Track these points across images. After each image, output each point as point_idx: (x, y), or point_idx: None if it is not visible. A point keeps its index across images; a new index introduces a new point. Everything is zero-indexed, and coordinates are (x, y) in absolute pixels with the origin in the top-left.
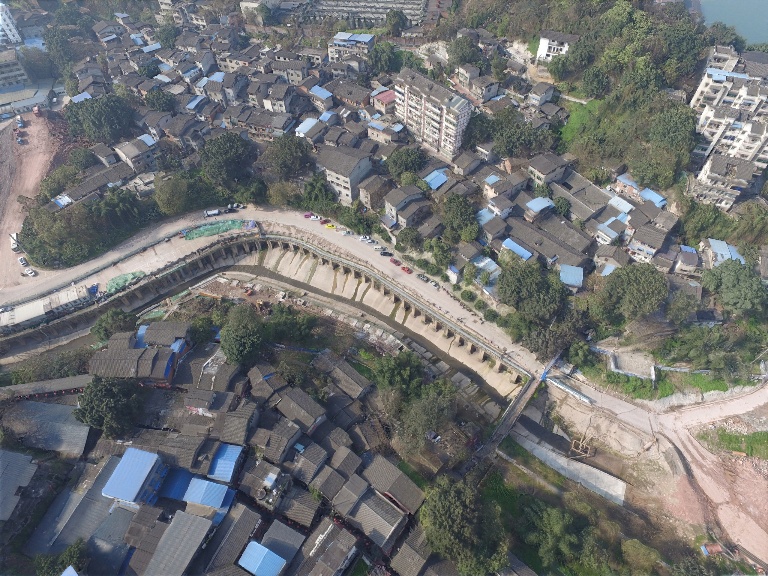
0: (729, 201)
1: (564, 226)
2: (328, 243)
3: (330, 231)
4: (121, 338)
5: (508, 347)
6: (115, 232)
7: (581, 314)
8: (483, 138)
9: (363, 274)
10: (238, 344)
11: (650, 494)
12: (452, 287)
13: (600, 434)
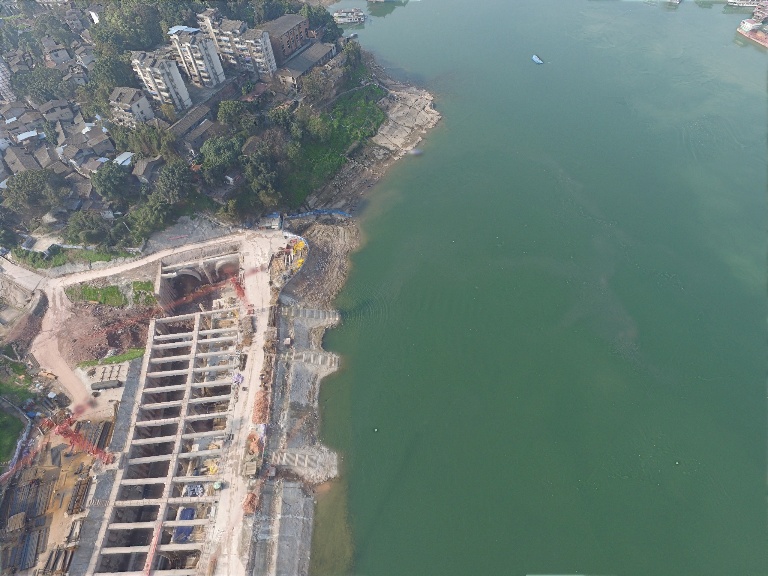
0: (134, 122)
1: (46, 151)
2: None
3: None
4: None
5: None
6: None
7: (3, 208)
8: (23, 91)
9: None
10: None
11: (7, 329)
12: None
13: (7, 294)
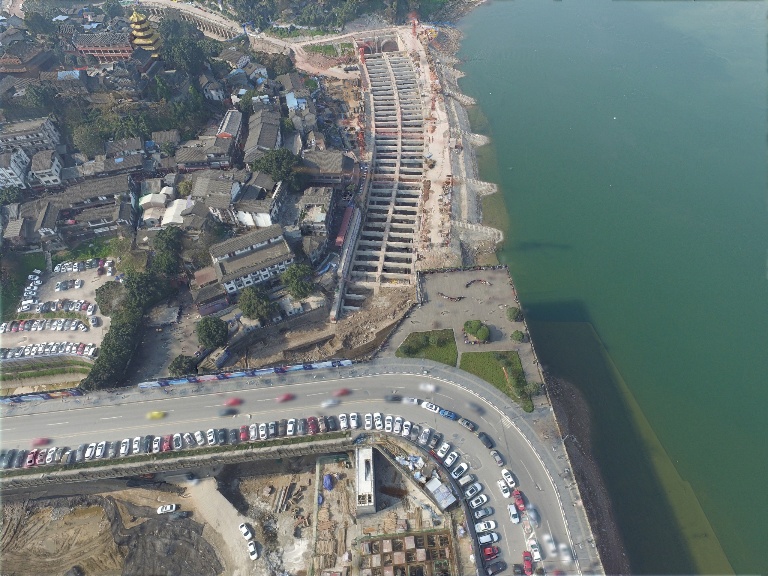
0: None
1: None
2: (172, 6)
3: (174, 3)
4: (63, 8)
5: (237, 28)
6: (69, 3)
7: (261, 5)
8: None
9: (185, 16)
10: (107, 3)
11: None
12: (221, 13)
13: None
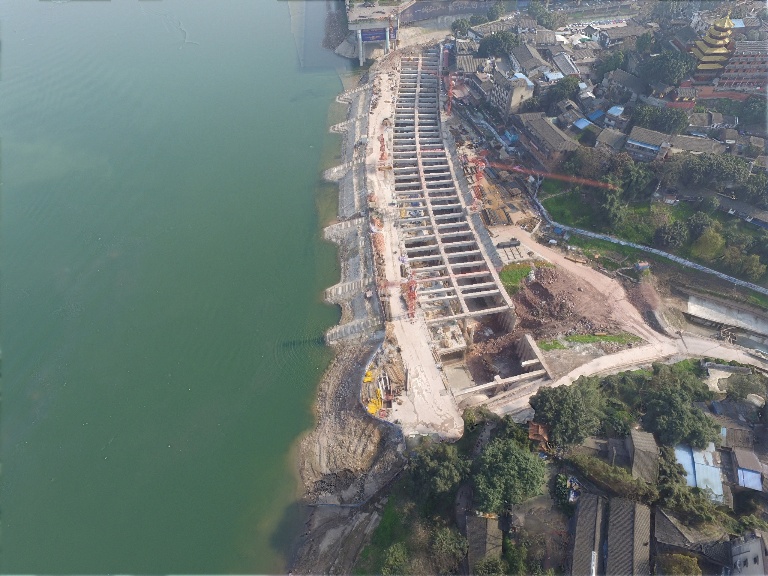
0: None
1: None
2: None
3: None
4: None
5: None
6: None
7: None
8: None
9: None
10: None
11: (671, 305)
12: None
13: None
